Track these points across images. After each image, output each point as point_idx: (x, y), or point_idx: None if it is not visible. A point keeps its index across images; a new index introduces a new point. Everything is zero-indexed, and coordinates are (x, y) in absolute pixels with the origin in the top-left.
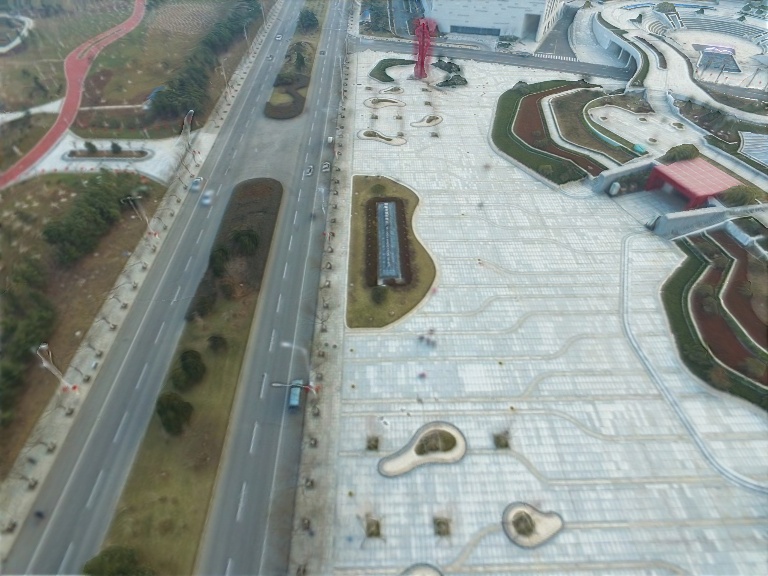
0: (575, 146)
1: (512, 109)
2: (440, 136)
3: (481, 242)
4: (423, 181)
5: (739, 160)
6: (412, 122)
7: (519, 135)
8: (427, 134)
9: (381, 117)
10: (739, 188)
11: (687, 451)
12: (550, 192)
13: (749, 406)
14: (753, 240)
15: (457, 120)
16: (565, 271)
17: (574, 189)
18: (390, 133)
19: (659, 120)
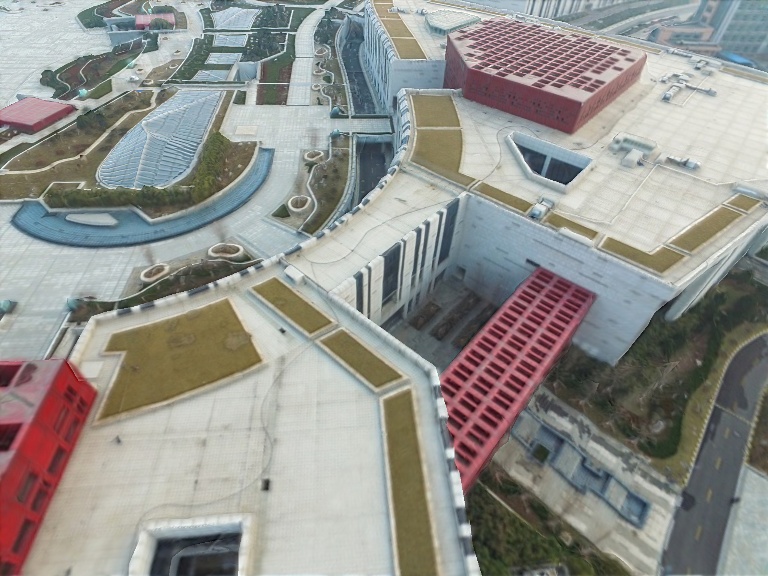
0: (120, 13)
1: (118, 0)
2: (49, 11)
3: (2, 47)
4: (5, 27)
5: (201, 16)
6: (39, 5)
7: (97, 9)
8: (41, 10)
9: (20, 2)
10: (155, 19)
11: (1, 101)
12: (80, 32)
13: (52, 90)
14: (145, 42)
15: (74, 5)
16: (34, 56)
17: (96, 31)
18: (15, 8)
19: (195, 3)
